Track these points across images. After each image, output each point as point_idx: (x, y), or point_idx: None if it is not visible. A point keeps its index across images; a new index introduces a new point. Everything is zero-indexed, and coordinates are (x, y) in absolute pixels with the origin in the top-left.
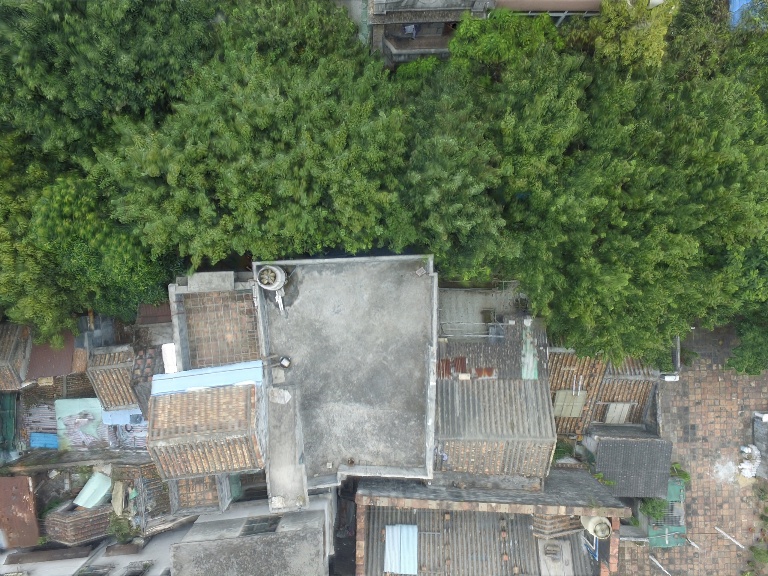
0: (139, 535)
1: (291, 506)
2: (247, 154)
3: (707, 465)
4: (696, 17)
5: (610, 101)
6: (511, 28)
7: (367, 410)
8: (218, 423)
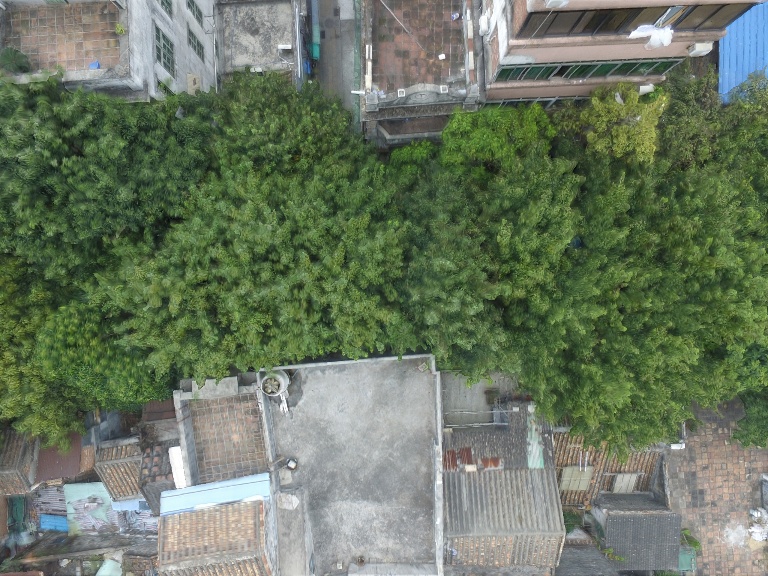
0: None
1: None
2: (247, 277)
3: (717, 530)
4: (686, 105)
5: (604, 203)
6: (503, 129)
7: (375, 507)
8: (228, 543)
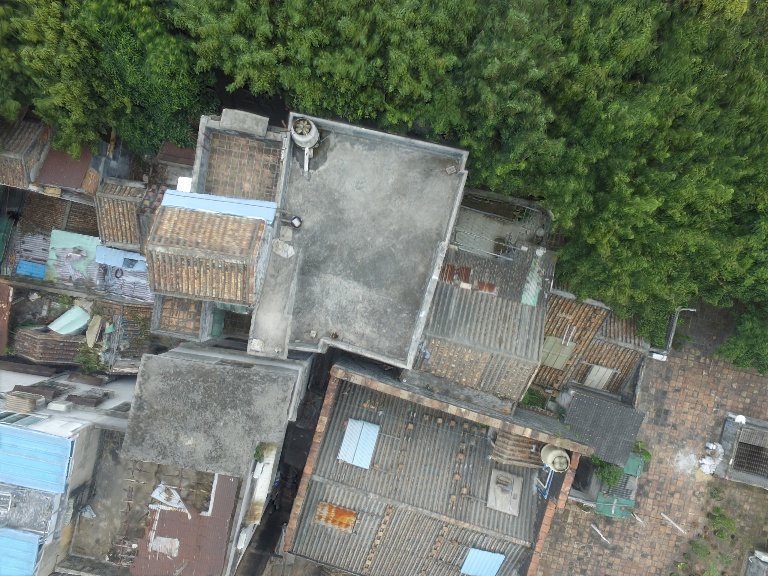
0: (105, 371)
1: (269, 352)
2: None
3: (670, 452)
4: None
5: (683, 38)
6: None
7: (363, 291)
8: (221, 246)
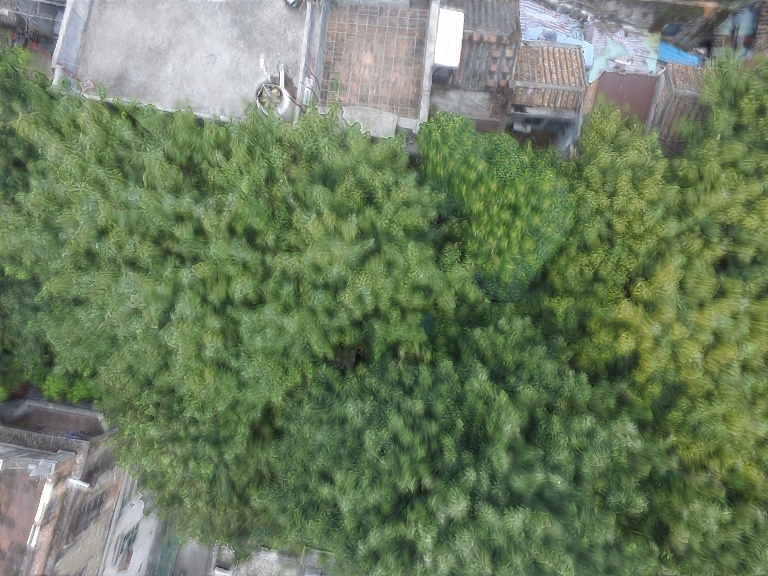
0: None
1: None
2: (217, 239)
3: None
4: None
5: None
6: None
7: None
8: None
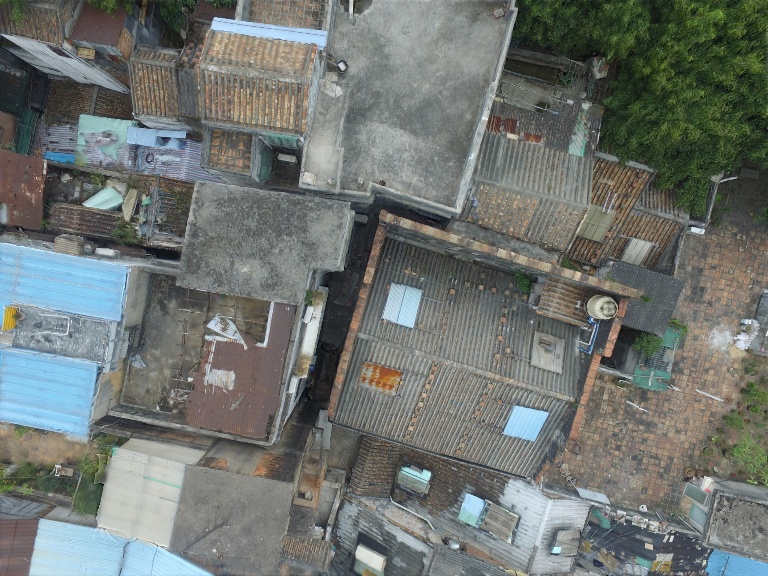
0: (143, 244)
1: (321, 186)
2: None
3: (705, 329)
4: None
5: None
6: None
7: (410, 139)
8: (274, 66)
